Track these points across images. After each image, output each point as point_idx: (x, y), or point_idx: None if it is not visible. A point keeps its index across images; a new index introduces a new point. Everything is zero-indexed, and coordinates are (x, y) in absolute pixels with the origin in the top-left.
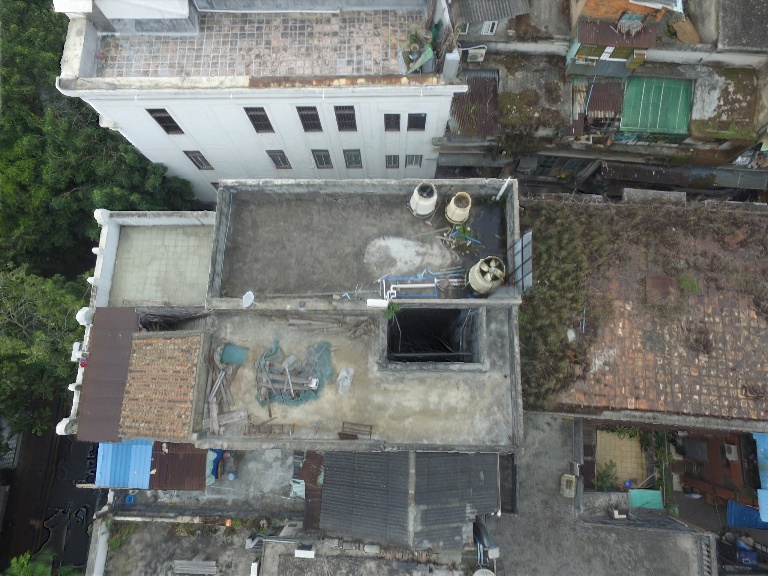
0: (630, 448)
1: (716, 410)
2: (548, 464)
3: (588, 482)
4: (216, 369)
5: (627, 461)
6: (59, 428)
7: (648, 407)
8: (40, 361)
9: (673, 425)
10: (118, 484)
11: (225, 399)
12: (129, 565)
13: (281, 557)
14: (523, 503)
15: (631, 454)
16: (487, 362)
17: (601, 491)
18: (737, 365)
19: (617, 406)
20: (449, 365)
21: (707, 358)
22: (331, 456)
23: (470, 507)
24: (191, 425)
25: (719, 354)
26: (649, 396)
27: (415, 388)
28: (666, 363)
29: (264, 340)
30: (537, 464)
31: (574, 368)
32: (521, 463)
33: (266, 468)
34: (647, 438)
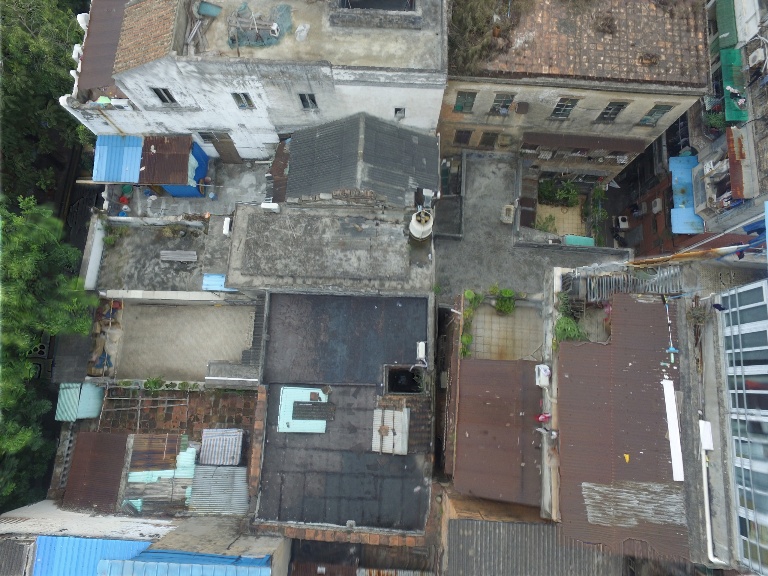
0: (572, 221)
1: (616, 74)
2: (492, 204)
3: (528, 226)
4: (194, 19)
5: (569, 231)
6: (62, 98)
7: (559, 72)
8: (45, 80)
9: (595, 143)
10: (112, 179)
11: (201, 42)
12: (121, 262)
13: (250, 214)
14: (469, 234)
15: (572, 226)
16: (419, 10)
17: (539, 230)
18: (636, 42)
19: (533, 72)
20: (388, 11)
21: (611, 37)
22: (296, 148)
23: (412, 180)
24: (172, 45)
25: (622, 35)
26: (561, 65)
27: (361, 40)
28: (577, 41)
29: (235, 2)
30: (482, 204)
31: (497, 39)
32: (468, 203)
33: (242, 192)
34: (586, 210)
